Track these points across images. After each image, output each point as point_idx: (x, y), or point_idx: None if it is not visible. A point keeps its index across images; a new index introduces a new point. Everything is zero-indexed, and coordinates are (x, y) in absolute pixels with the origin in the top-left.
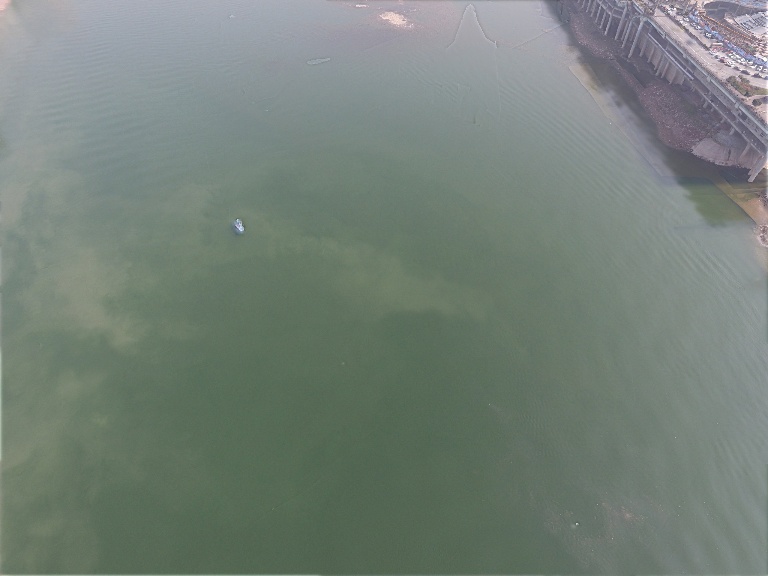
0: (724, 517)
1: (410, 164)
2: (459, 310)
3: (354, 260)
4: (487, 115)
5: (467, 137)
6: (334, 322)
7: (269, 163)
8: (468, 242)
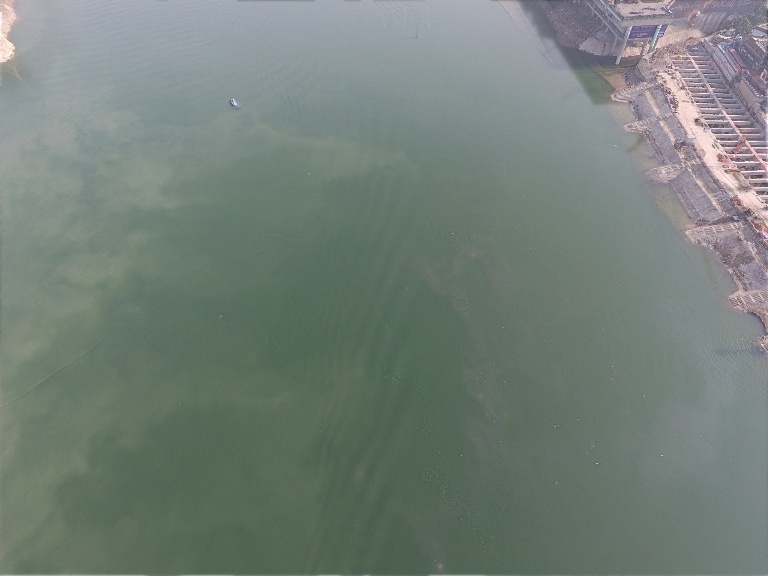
0: (545, 228)
1: (364, 65)
2: (391, 142)
3: (318, 119)
4: (425, 29)
5: (409, 46)
6: (303, 153)
7: (254, 63)
8: (402, 105)
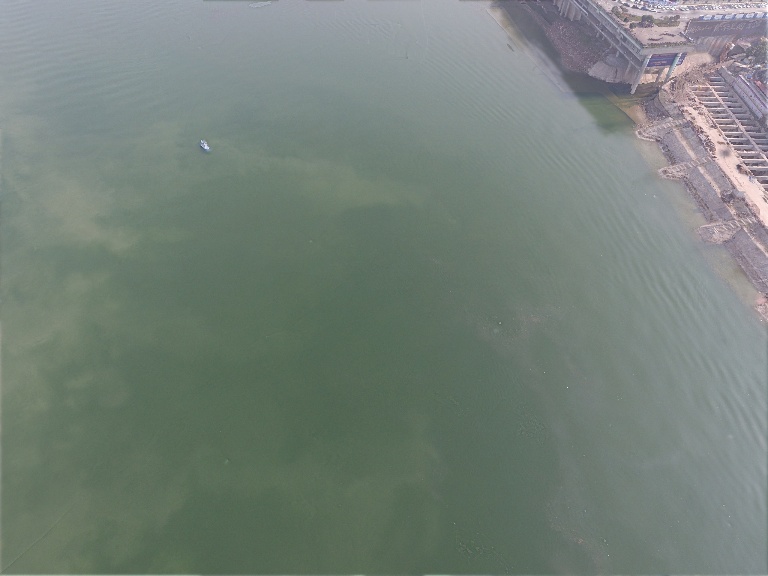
0: (604, 310)
1: (353, 93)
2: (403, 197)
3: (311, 167)
4: (417, 49)
5: (401, 69)
6: (299, 213)
7: (225, 93)
8: (407, 147)
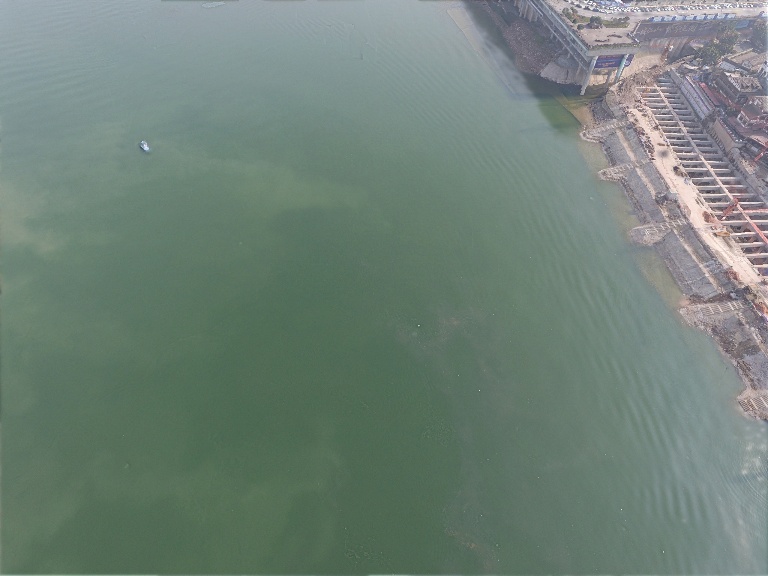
0: (526, 312)
1: (303, 93)
2: (339, 198)
3: (250, 168)
4: (371, 50)
5: (354, 70)
6: (233, 215)
7: (170, 94)
8: (349, 148)
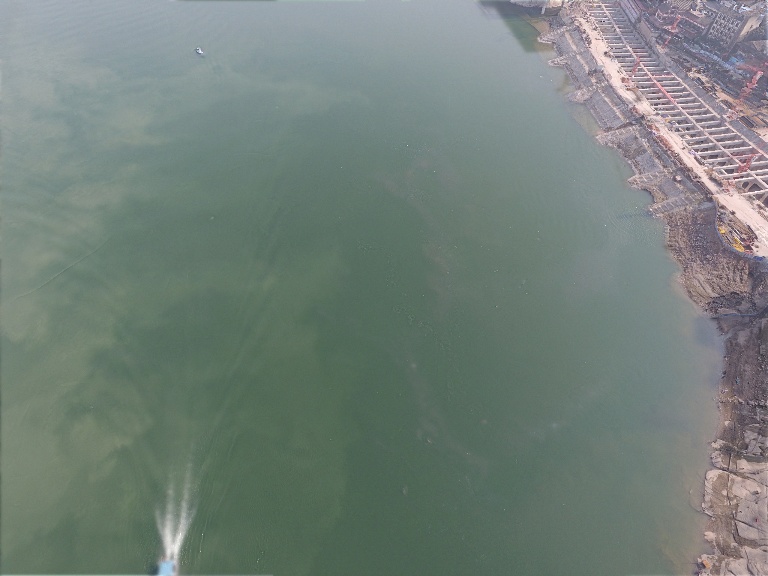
0: (484, 139)
1: (319, 19)
2: (349, 80)
3: (281, 63)
4: None
5: (359, 2)
6: (270, 92)
7: (215, 16)
8: (356, 49)
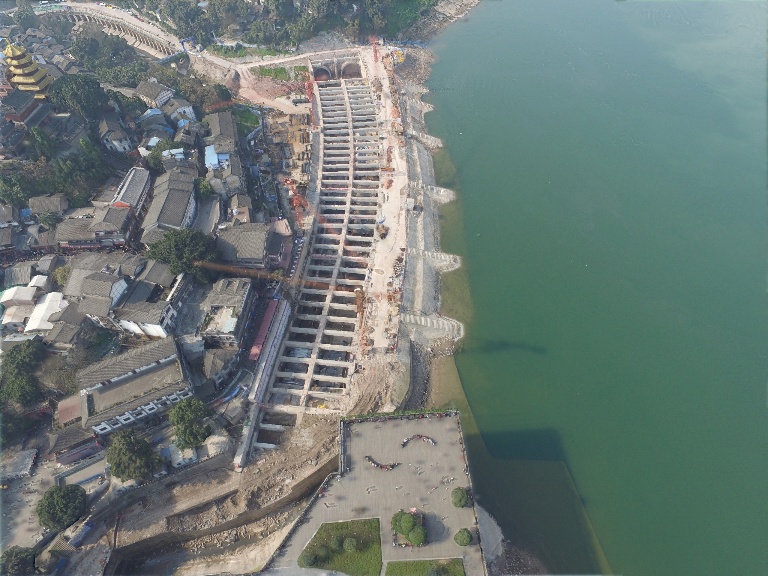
0: (555, 149)
1: None
2: (758, 245)
3: None
4: None
5: None
6: None
7: None
8: None
